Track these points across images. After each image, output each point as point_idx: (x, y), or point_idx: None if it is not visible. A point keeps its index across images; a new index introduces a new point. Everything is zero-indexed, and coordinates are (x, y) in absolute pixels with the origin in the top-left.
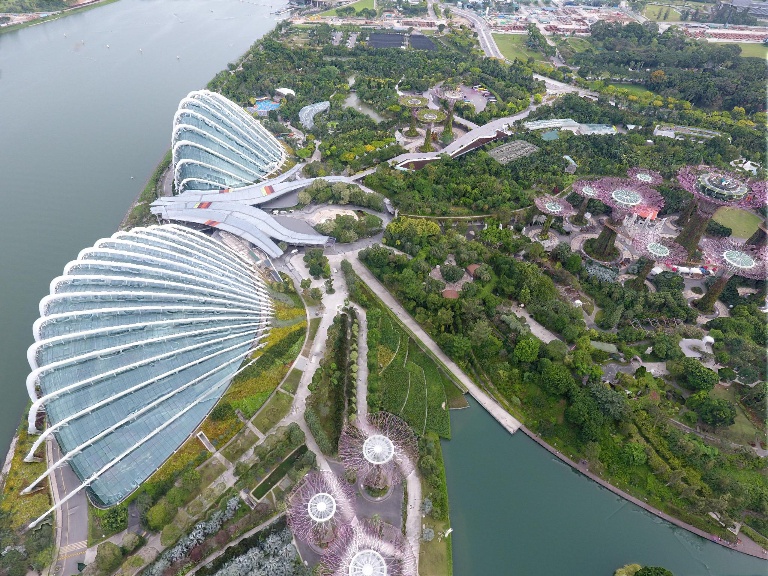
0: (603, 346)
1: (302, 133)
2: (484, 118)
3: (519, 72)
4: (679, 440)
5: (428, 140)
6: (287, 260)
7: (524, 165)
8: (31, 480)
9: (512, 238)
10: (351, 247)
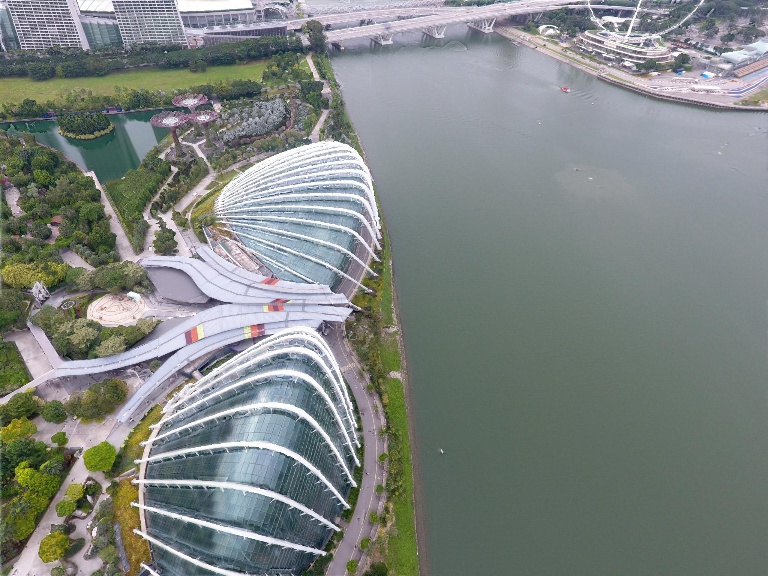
0: None
1: None
2: None
3: None
4: (8, 147)
5: None
6: None
7: None
8: None
9: None
10: None
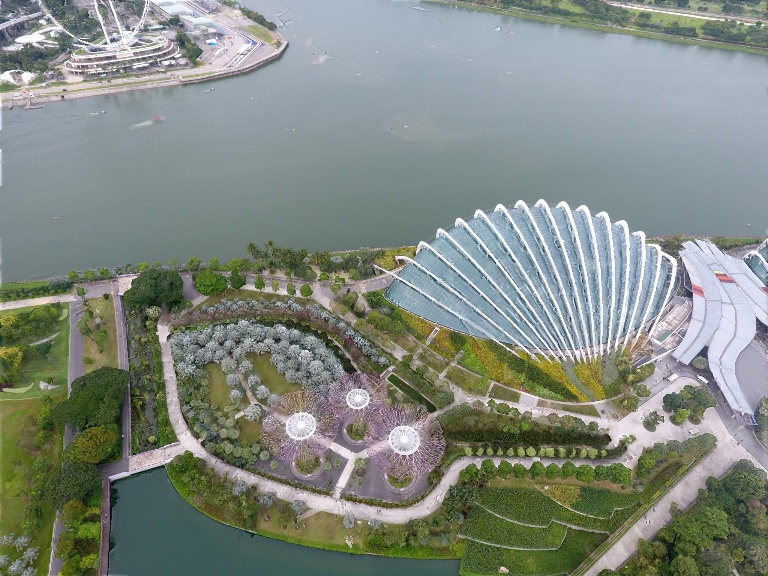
0: None
1: None
2: None
3: None
4: None
5: None
6: (682, 373)
7: None
8: None
9: None
10: (759, 453)
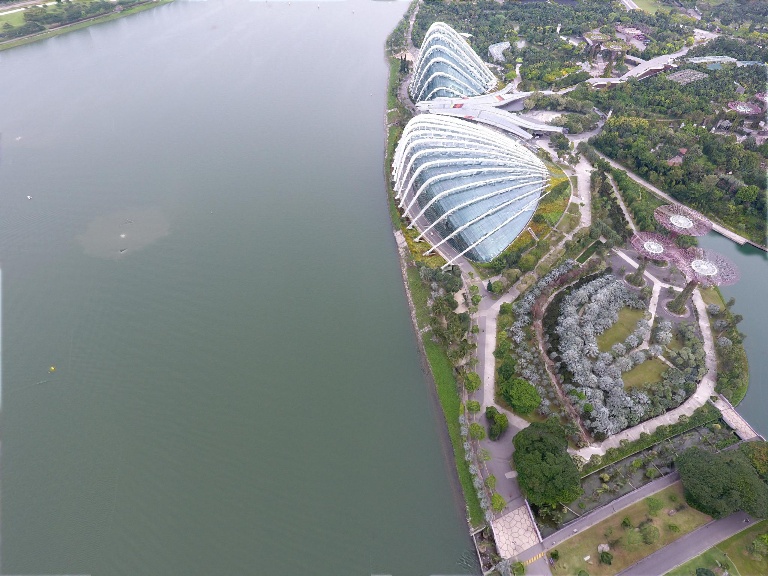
0: None
1: (494, 65)
2: (649, 54)
3: (669, 20)
4: None
5: (610, 68)
6: (534, 143)
7: (699, 86)
8: (425, 249)
9: (707, 133)
10: (578, 137)
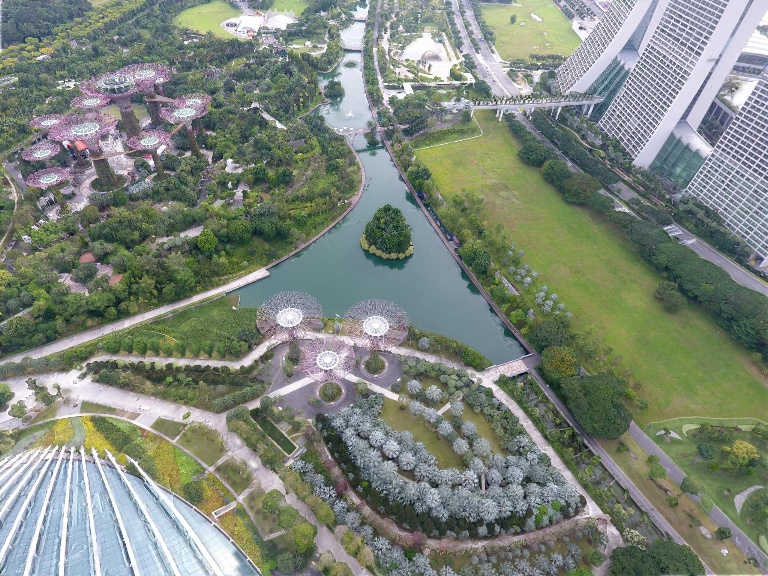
0: (217, 205)
1: None
2: None
3: None
4: (298, 195)
5: None
6: None
7: None
8: None
9: (60, 224)
10: None
